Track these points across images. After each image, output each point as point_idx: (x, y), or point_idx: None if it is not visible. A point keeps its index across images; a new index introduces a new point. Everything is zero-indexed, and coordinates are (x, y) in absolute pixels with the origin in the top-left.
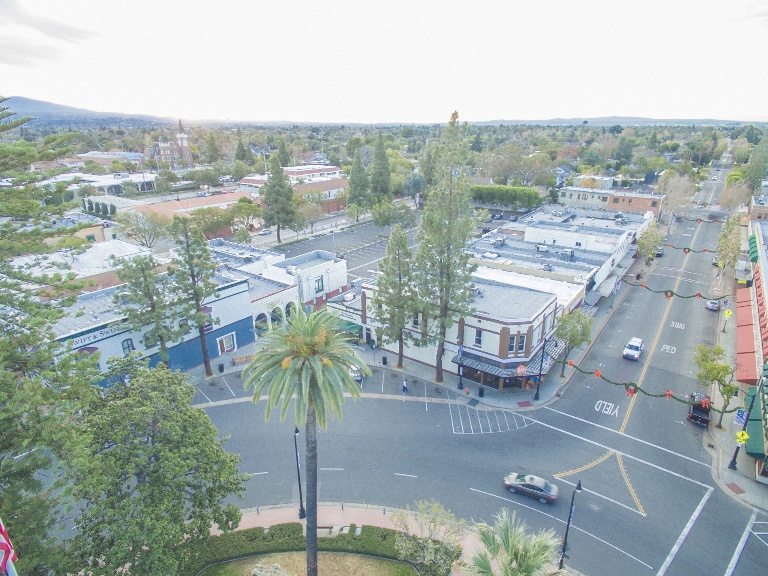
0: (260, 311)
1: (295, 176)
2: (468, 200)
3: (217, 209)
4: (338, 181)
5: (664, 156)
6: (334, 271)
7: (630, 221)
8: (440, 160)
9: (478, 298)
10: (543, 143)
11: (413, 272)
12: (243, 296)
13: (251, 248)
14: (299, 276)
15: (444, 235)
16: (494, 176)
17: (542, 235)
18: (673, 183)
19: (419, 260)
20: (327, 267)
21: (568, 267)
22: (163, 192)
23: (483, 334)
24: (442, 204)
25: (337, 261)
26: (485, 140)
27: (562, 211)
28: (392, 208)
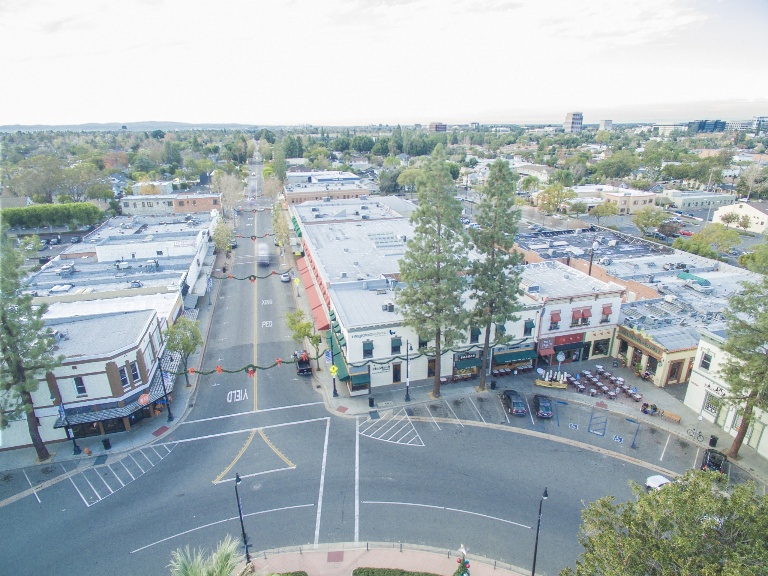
0: None
1: None
2: (3, 228)
3: None
4: None
5: (209, 158)
6: None
7: (200, 221)
8: None
9: (62, 342)
10: (83, 151)
11: None
12: None
13: None
14: None
15: None
16: (31, 194)
17: (117, 252)
18: (224, 181)
19: None
20: None
21: (157, 278)
22: None
23: (85, 380)
24: None
25: None
26: (1, 151)
27: (131, 222)
28: None
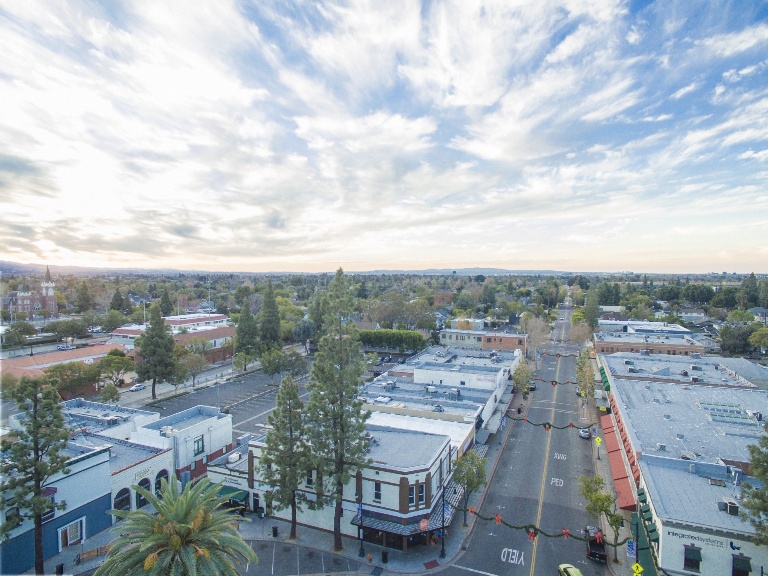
0: (122, 485)
1: (178, 325)
2: (358, 344)
3: (80, 364)
4: (225, 329)
5: (520, 300)
6: (217, 428)
7: (503, 359)
8: (329, 307)
9: (374, 447)
10: (421, 290)
11: (305, 425)
12: (101, 469)
13: (118, 408)
14: (175, 438)
15: (336, 381)
16: (380, 321)
17: (429, 376)
18: (532, 323)
19: (311, 410)
20: (209, 424)
21: (457, 407)
22: (13, 346)
23: (382, 487)
24: (333, 349)
25: (221, 417)
26: (370, 288)
27: (444, 352)
28: (282, 355)
